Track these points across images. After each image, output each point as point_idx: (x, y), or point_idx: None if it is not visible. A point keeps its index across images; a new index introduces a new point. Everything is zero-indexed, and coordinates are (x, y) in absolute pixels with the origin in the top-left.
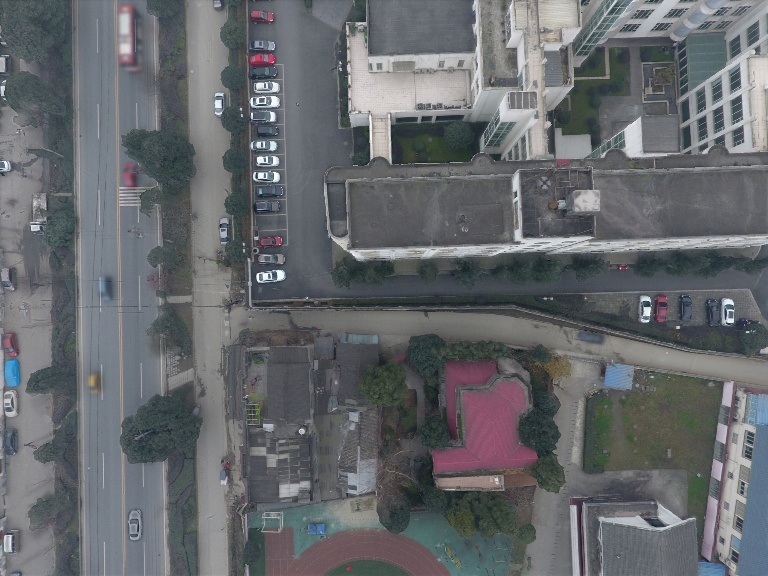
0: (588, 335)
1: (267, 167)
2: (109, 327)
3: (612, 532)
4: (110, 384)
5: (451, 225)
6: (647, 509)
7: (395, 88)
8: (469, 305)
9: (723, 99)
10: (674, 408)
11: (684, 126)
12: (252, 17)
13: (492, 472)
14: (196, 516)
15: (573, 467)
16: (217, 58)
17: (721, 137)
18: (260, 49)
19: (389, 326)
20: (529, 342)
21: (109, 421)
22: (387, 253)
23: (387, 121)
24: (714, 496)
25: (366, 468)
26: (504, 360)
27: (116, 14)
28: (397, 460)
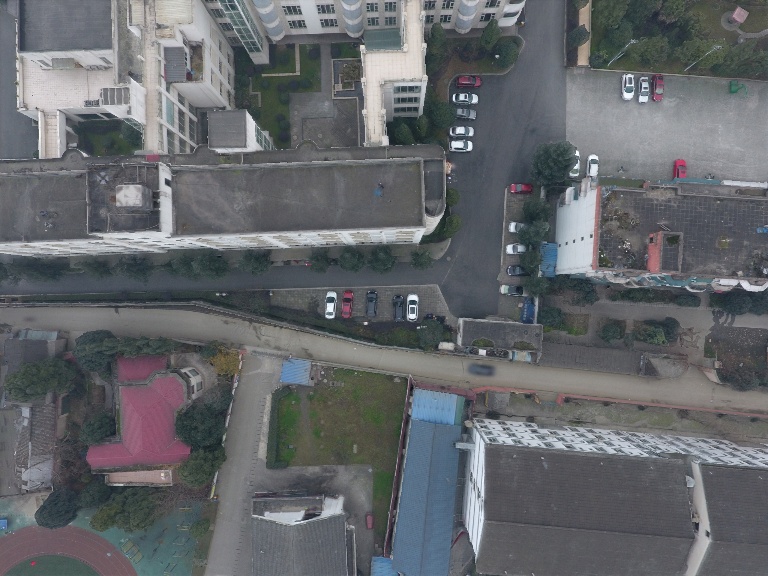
0: (272, 331)
1: None
2: None
3: (258, 527)
4: None
5: (42, 221)
6: (314, 504)
7: (68, 85)
8: (158, 301)
9: None
10: (360, 404)
11: None
12: None
13: (150, 467)
14: None
15: (259, 462)
16: None
17: None
18: None
19: (80, 322)
20: (218, 338)
21: None
22: (7, 249)
23: None
24: None
25: (40, 464)
26: (191, 356)
27: None
28: (65, 456)
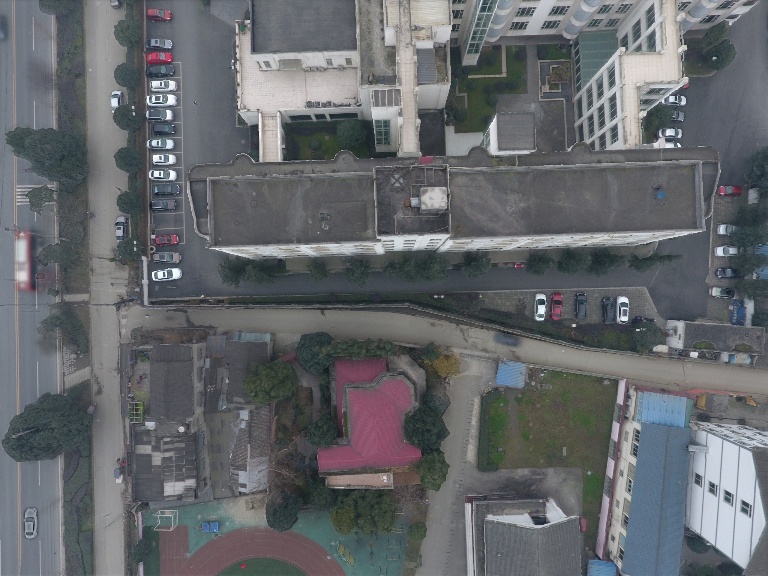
0: (483, 333)
1: (164, 165)
2: (6, 325)
3: (494, 530)
4: (6, 382)
5: (314, 223)
6: (536, 507)
7: (286, 86)
8: (365, 303)
9: (603, 97)
10: (569, 406)
11: (578, 124)
12: (148, 15)
13: (378, 470)
14: (92, 514)
15: (468, 465)
16: (115, 56)
17: (603, 135)
18: (157, 47)
19: (286, 324)
20: (425, 340)
21: (5, 419)
22: (260, 251)
23: (278, 119)
24: (607, 494)
25: (257, 466)
26: (400, 358)
27: (14, 12)
28: (286, 458)
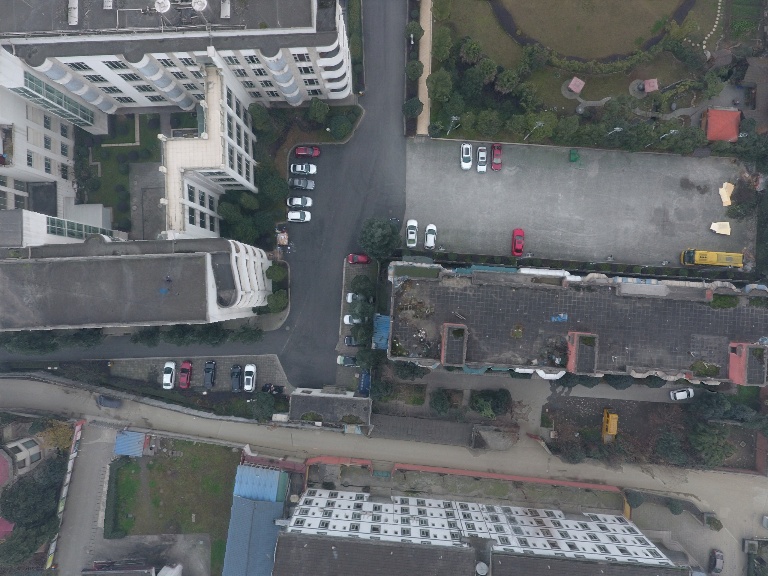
0: (109, 402)
1: None
2: None
3: None
4: None
5: None
6: None
7: None
8: None
9: None
10: (199, 473)
11: None
12: None
13: None
14: None
15: (99, 531)
16: None
17: None
18: None
19: None
20: (59, 407)
21: None
22: None
23: None
24: None
25: None
26: None
27: None
28: None
